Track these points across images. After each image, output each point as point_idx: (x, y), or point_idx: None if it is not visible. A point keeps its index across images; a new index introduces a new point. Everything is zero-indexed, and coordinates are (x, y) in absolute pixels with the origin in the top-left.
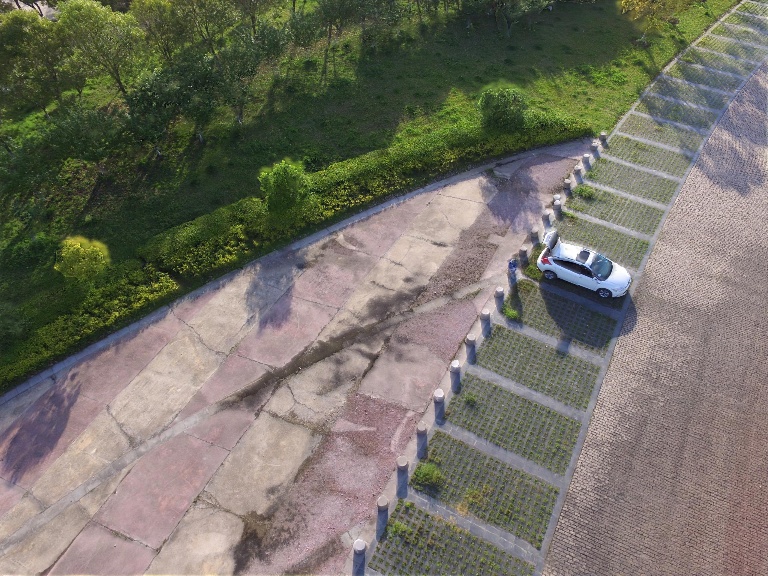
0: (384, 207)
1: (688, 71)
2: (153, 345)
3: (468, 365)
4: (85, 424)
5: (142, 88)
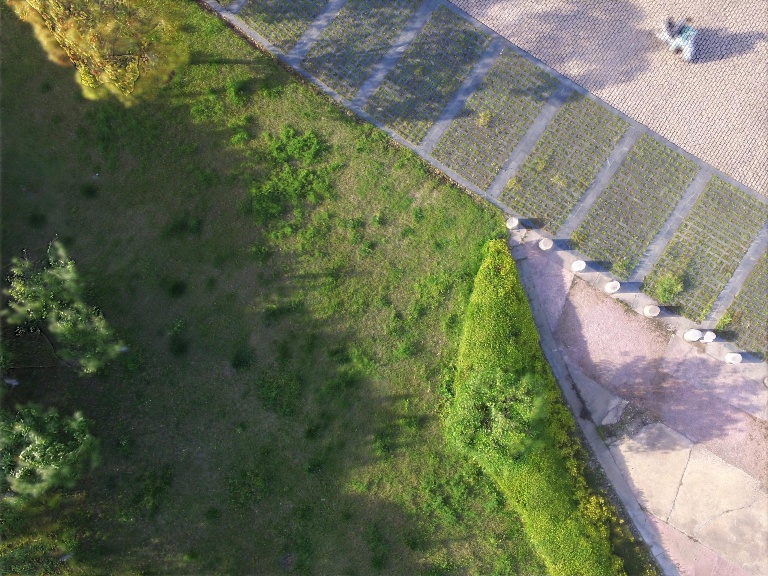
0: None
1: (277, 6)
2: None
3: None
4: None
5: None
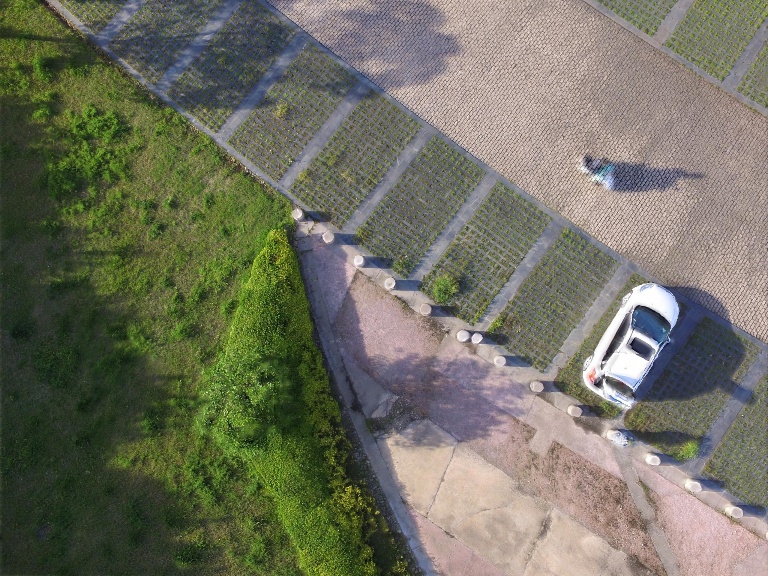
0: None
1: None
2: None
3: (767, 518)
4: None
5: None
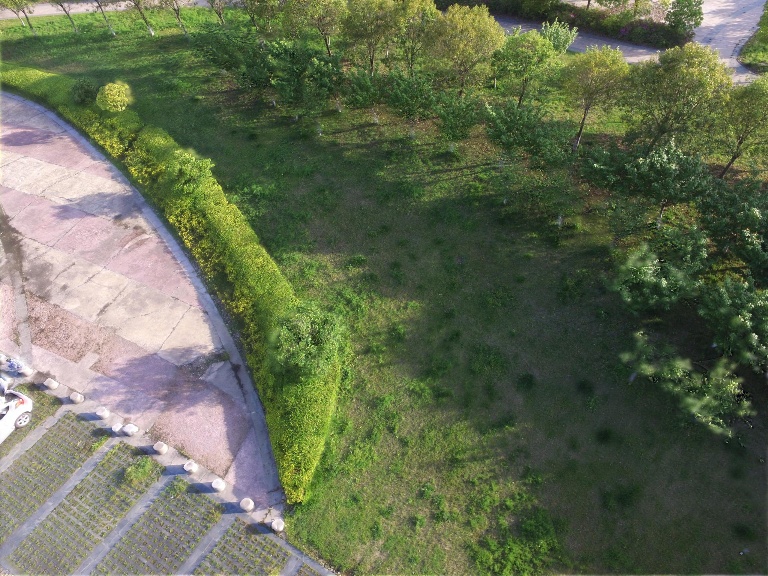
0: (182, 262)
1: None
2: (68, 161)
3: None
4: (17, 152)
5: (274, 50)
